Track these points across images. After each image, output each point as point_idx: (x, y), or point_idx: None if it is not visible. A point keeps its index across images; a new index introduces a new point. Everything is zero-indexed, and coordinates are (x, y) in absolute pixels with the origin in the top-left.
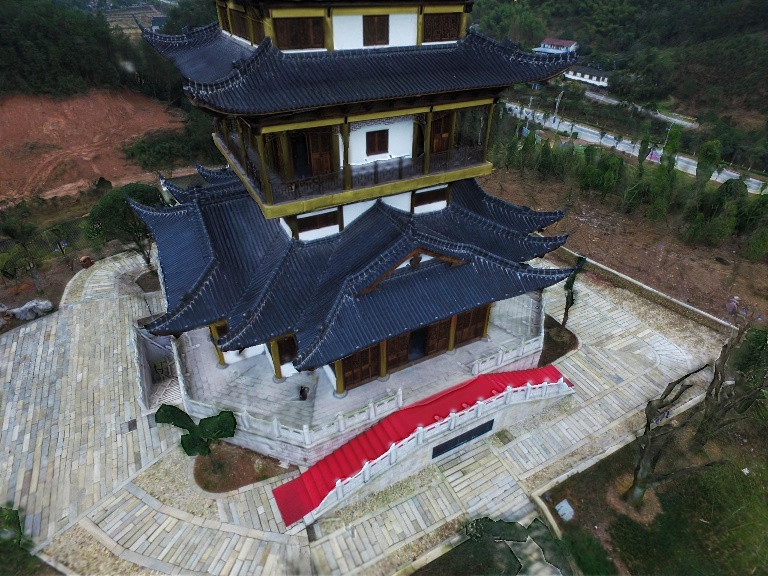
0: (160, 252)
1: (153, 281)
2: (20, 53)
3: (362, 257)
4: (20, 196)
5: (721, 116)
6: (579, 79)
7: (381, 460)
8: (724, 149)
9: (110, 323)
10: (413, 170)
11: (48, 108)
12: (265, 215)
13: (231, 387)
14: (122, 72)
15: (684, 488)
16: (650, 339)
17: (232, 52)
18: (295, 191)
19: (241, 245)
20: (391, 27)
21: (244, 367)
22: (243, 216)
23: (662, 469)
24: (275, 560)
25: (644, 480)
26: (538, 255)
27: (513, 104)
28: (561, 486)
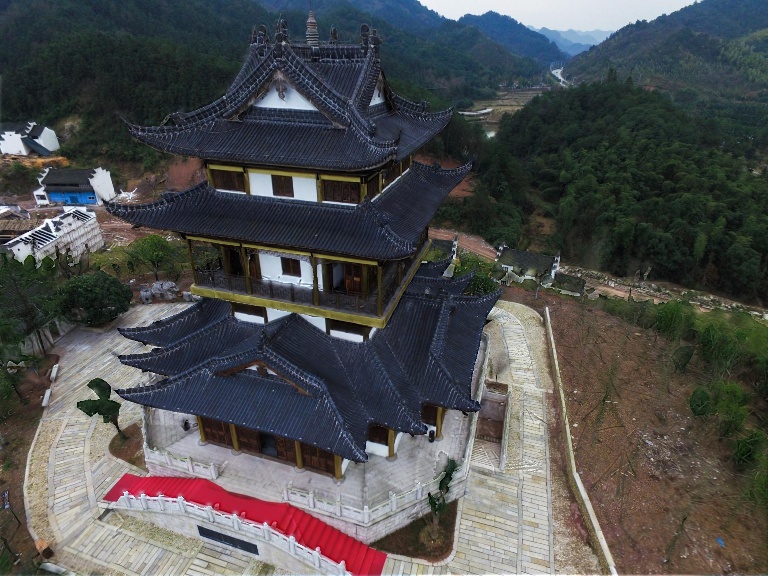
0: None
1: None
2: None
3: None
4: None
5: None
6: None
7: None
8: None
9: None
10: (304, 298)
11: None
12: None
13: None
14: (452, 145)
15: None
16: None
17: None
18: (212, 282)
19: (223, 305)
20: (294, 185)
21: None
22: None
23: None
24: (76, 511)
25: None
26: (401, 430)
27: None
28: None
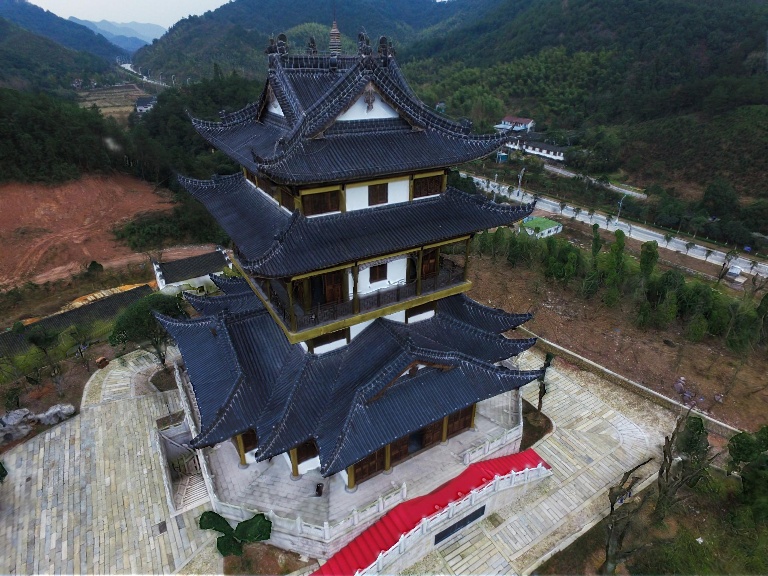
0: (186, 362)
1: (167, 380)
2: (17, 145)
3: (368, 368)
4: (10, 281)
5: (665, 187)
6: (538, 153)
7: (392, 550)
8: (670, 219)
9: (131, 424)
10: (408, 293)
11: (41, 194)
12: (290, 341)
13: (253, 487)
14: (112, 157)
15: (649, 560)
16: (613, 420)
17: (260, 205)
18: (315, 320)
19: (262, 358)
20: (389, 191)
21: (263, 466)
22: (263, 331)
23: (630, 543)
24: None
25: (613, 556)
26: None
27: (480, 178)
28: (546, 565)
